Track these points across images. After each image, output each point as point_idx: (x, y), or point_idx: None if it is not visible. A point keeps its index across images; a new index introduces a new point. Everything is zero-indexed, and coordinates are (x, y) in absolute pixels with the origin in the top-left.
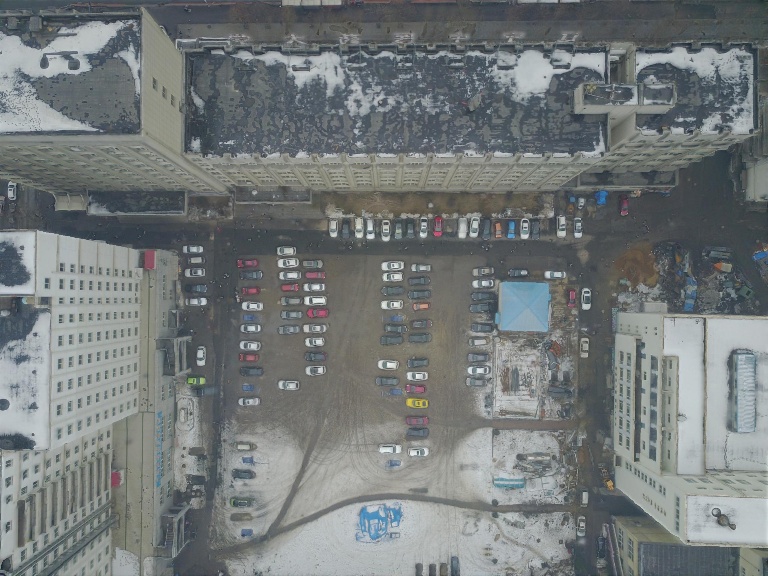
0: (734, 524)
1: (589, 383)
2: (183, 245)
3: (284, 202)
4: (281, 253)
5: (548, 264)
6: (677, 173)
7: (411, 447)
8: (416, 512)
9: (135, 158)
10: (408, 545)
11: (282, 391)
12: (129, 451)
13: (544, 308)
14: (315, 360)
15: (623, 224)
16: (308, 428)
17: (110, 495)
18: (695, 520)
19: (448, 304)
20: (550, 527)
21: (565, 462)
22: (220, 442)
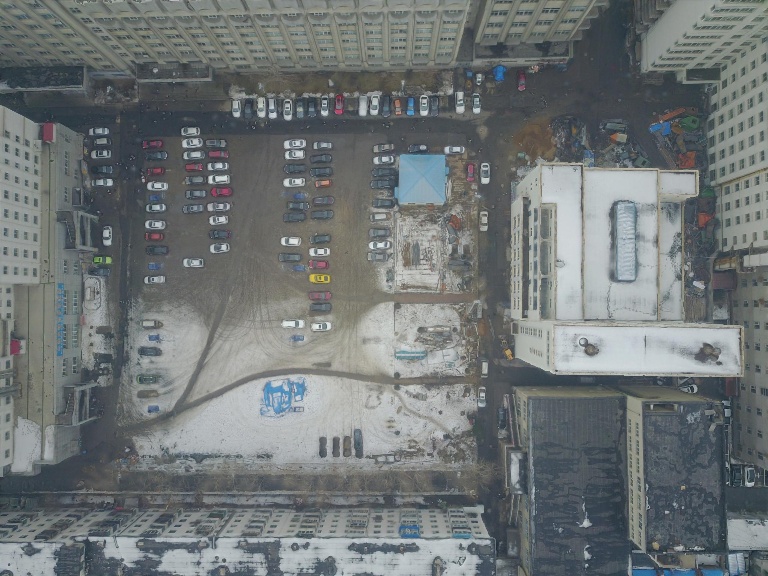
0: (597, 348)
1: (489, 256)
2: (89, 128)
3: (184, 79)
4: (185, 133)
5: (448, 140)
6: (572, 45)
7: (314, 322)
8: (319, 386)
9: (8, 1)
10: (312, 419)
11: (187, 269)
12: (31, 322)
13: (440, 179)
14: (219, 237)
15: (521, 99)
16: (213, 305)
17: (12, 364)
18: (563, 350)
19: (350, 181)
20: (452, 399)
21: (465, 334)
22: (127, 321)
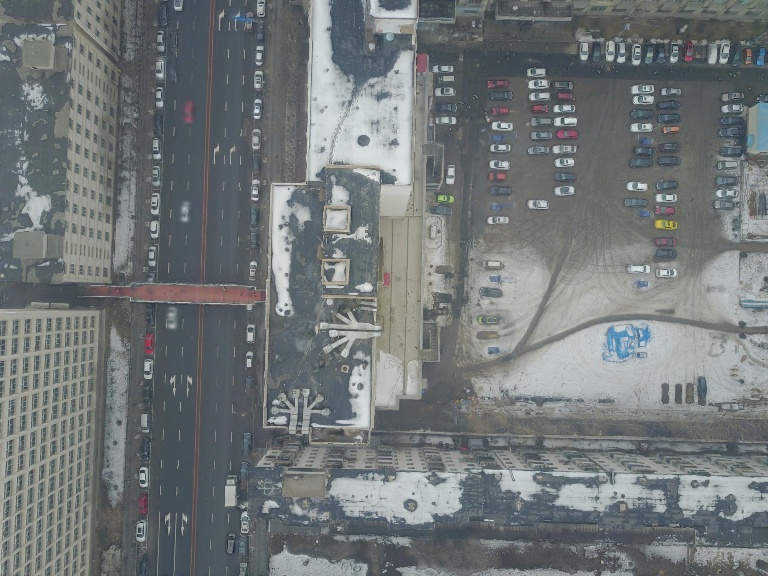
0: None
1: None
2: (433, 65)
3: (545, 18)
4: (532, 74)
5: None
6: None
7: (659, 268)
8: (663, 333)
9: None
10: (654, 365)
11: (530, 211)
12: (394, 255)
13: None
14: (565, 180)
15: None
16: (556, 248)
17: None
18: None
19: (696, 129)
20: None
21: None
22: (467, 261)
